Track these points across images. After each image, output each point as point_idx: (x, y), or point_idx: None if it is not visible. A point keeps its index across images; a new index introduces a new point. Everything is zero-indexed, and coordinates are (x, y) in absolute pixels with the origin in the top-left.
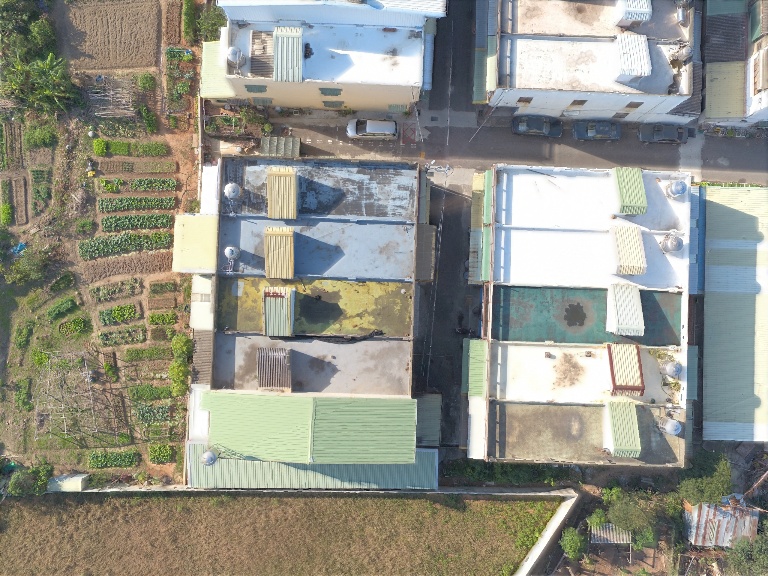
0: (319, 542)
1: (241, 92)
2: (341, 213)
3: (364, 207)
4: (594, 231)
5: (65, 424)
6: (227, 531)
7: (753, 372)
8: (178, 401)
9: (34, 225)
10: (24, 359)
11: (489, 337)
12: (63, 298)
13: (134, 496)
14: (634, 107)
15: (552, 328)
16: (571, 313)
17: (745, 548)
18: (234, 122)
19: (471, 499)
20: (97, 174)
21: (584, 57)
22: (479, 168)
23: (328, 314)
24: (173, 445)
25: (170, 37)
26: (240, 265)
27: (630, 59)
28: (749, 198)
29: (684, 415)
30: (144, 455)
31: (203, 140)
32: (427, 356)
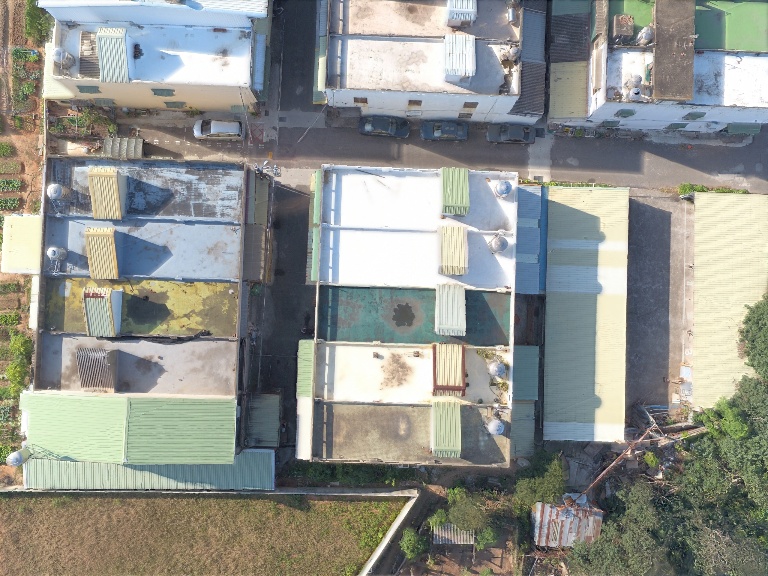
0: (161, 543)
1: (79, 93)
2: (169, 214)
3: (192, 208)
4: (423, 231)
5: None
6: (69, 532)
7: (594, 372)
8: None
9: None
10: None
11: None
12: None
13: None
14: (472, 107)
15: (380, 328)
16: (399, 313)
17: (582, 548)
18: (81, 123)
19: (315, 500)
20: None
21: (415, 57)
22: None
23: (155, 315)
24: (15, 446)
25: (17, 38)
26: (67, 266)
27: (455, 59)
28: (591, 198)
29: (509, 415)
30: None
31: (48, 141)
32: (273, 357)
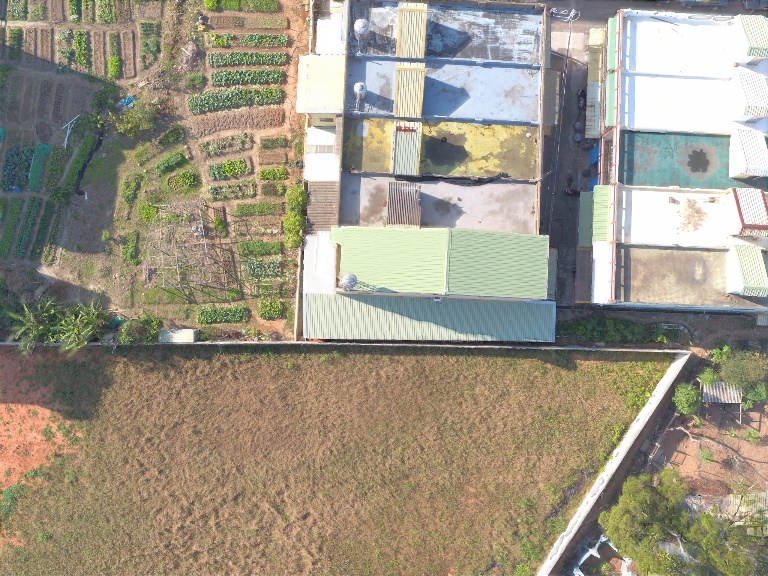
0: (431, 400)
1: None
2: (466, 56)
3: (489, 51)
4: (717, 79)
5: (178, 273)
6: (338, 389)
7: None
8: (289, 257)
9: (143, 78)
10: (132, 213)
11: (616, 179)
12: (172, 152)
13: (244, 352)
14: None
15: (676, 174)
16: (694, 159)
17: None
18: None
19: (582, 359)
20: (207, 28)
21: None
22: (588, 33)
23: (454, 156)
24: (284, 301)
25: None
26: (365, 106)
27: None
28: None
29: None
30: (254, 311)
31: None
32: None
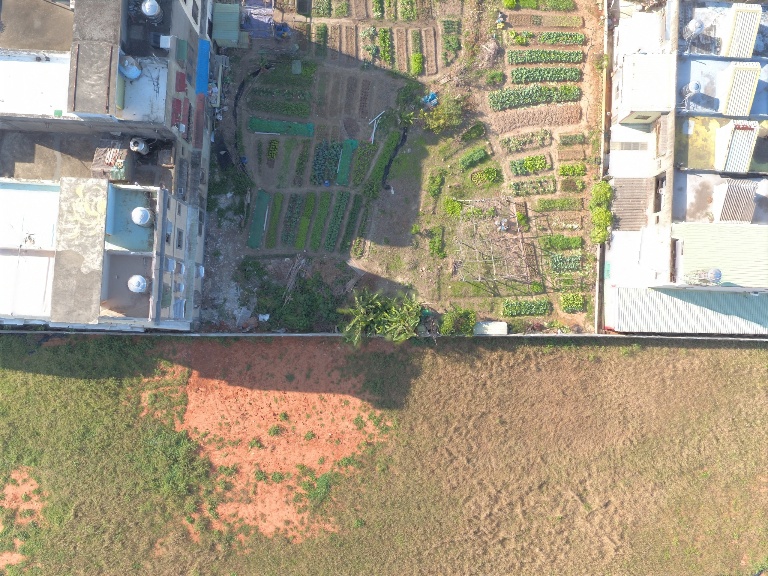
0: (725, 392)
1: None
2: None
3: None
4: None
5: None
6: (636, 380)
7: None
8: (588, 252)
9: (445, 75)
10: (436, 207)
11: None
12: (474, 148)
13: (547, 344)
14: None
15: None
16: None
17: None
18: None
19: None
20: (505, 26)
21: None
22: None
23: None
24: (584, 295)
25: None
26: (690, 104)
27: None
28: None
29: None
30: (555, 304)
31: None
32: None
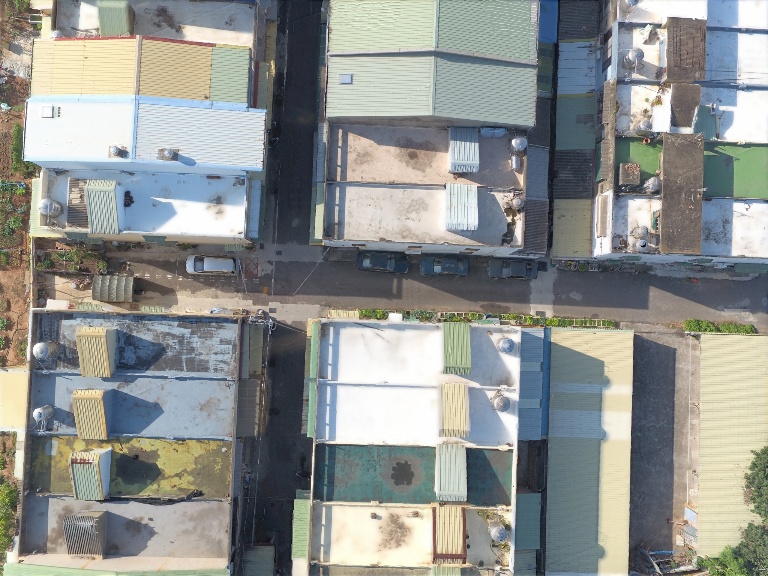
0: None
1: None
2: (160, 368)
3: (184, 362)
4: (423, 387)
5: None
6: None
7: (597, 521)
8: (6, 550)
9: None
10: None
11: None
12: None
13: None
14: (474, 250)
15: (378, 487)
16: (398, 472)
17: None
18: (69, 257)
19: None
20: None
21: (415, 205)
22: (323, 304)
23: (146, 474)
24: None
25: (3, 169)
26: (54, 423)
27: (457, 212)
28: (595, 340)
29: None
30: None
31: (35, 277)
32: (268, 499)
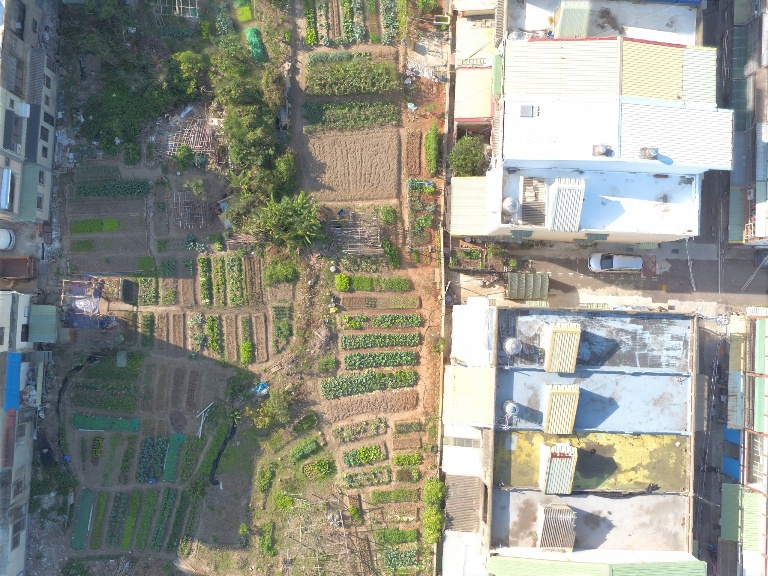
0: None
1: (497, 232)
2: (615, 364)
3: (637, 358)
4: None
5: (320, 574)
6: None
7: None
8: (424, 544)
9: (276, 363)
10: (267, 502)
11: None
12: (306, 438)
13: None
14: None
15: None
16: None
17: None
18: (475, 255)
19: None
20: (339, 310)
21: None
22: (720, 301)
23: (603, 468)
24: None
25: (410, 168)
26: (513, 418)
27: None
28: None
29: None
30: None
31: (446, 274)
32: None
